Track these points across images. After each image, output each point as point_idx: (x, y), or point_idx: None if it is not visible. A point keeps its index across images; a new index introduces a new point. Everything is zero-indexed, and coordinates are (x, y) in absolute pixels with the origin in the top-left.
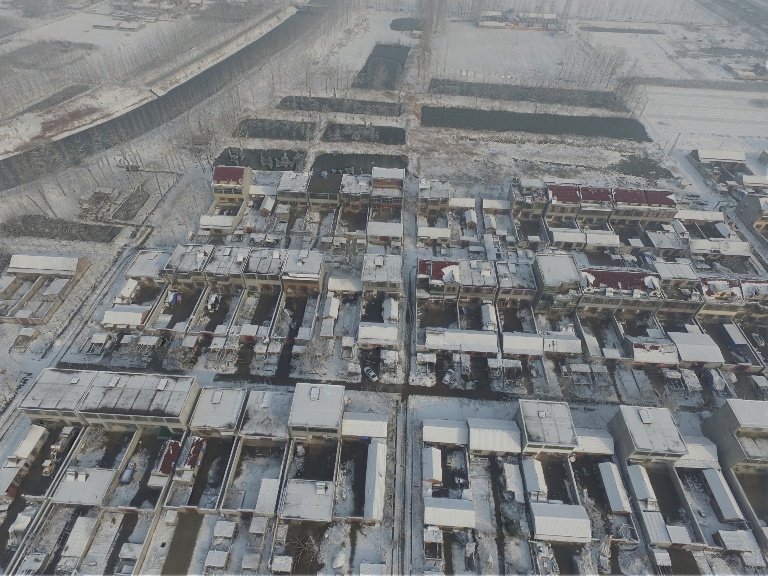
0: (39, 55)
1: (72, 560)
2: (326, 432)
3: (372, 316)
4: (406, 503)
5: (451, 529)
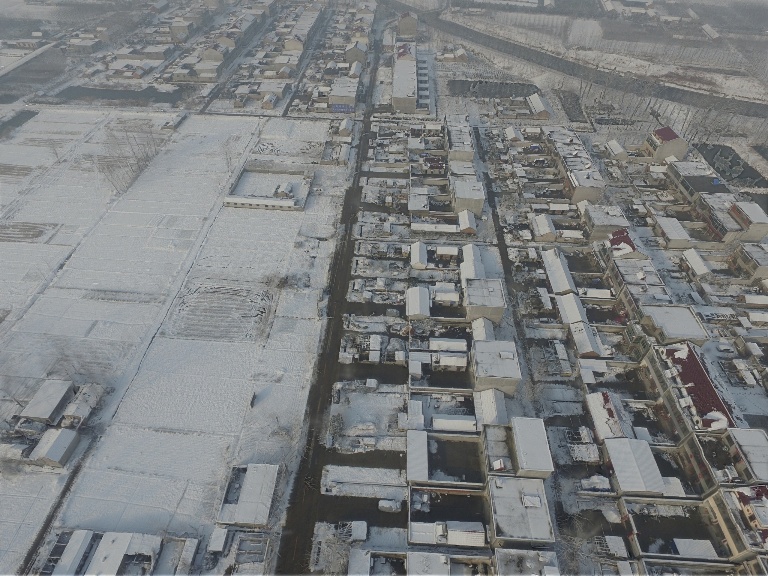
0: (765, 48)
1: None
2: None
3: None
4: None
5: None
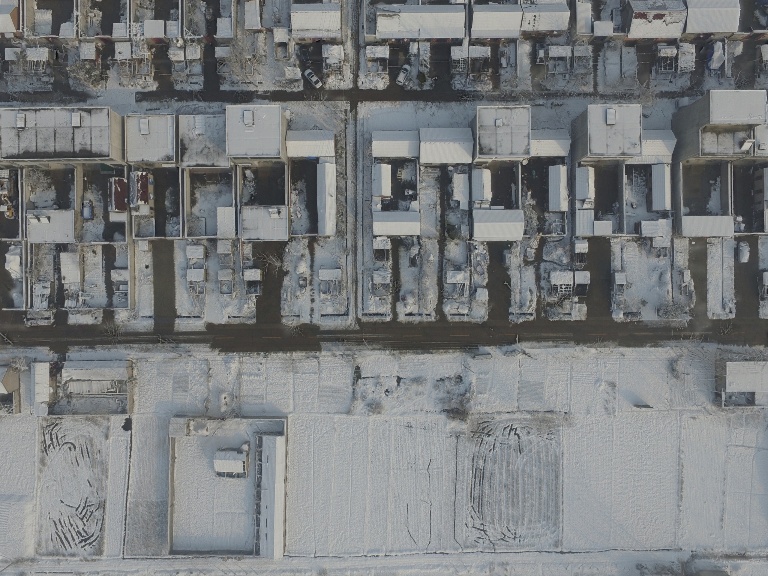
0: None
1: (74, 285)
2: (269, 159)
3: None
4: (358, 217)
5: (399, 236)
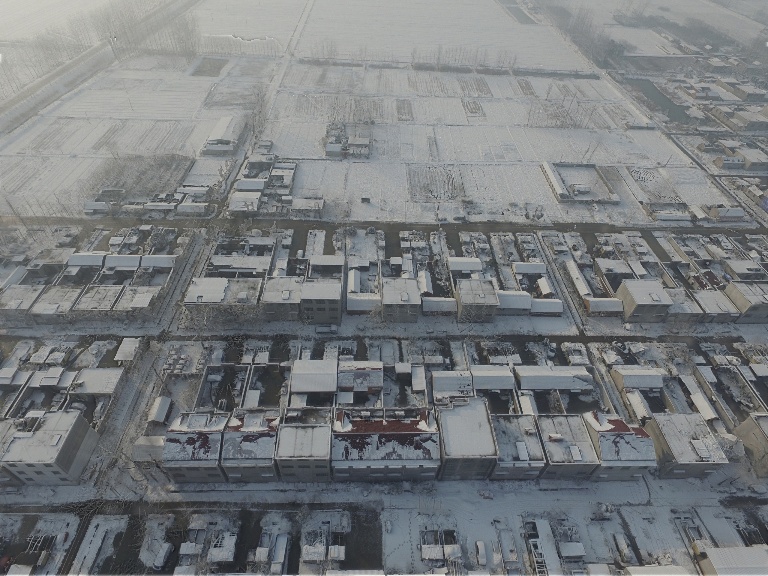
0: None
1: None
2: None
3: (656, 410)
4: (554, 276)
5: None
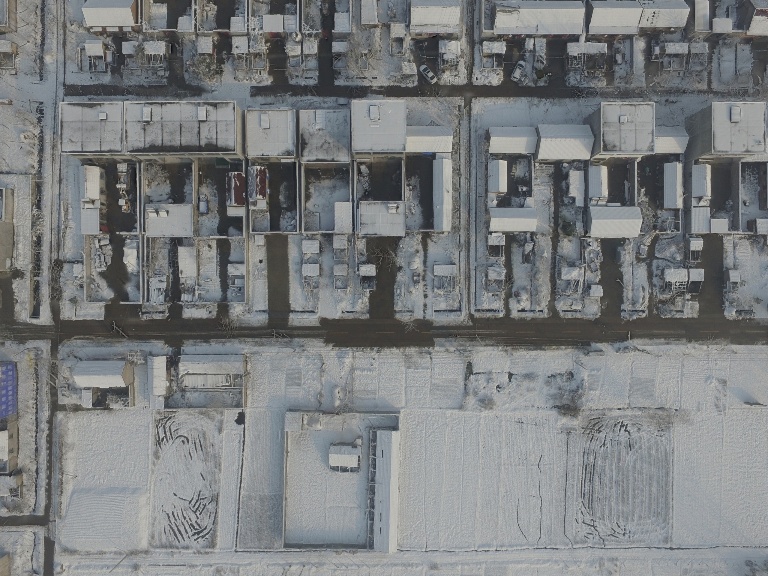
0: None
1: (190, 279)
2: (391, 154)
3: None
4: (471, 213)
5: None
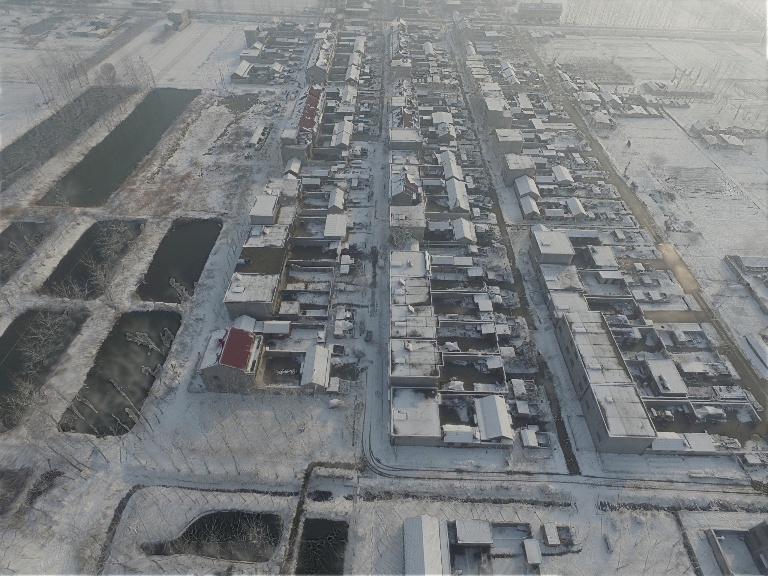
0: None
1: None
2: None
3: None
4: None
5: None
